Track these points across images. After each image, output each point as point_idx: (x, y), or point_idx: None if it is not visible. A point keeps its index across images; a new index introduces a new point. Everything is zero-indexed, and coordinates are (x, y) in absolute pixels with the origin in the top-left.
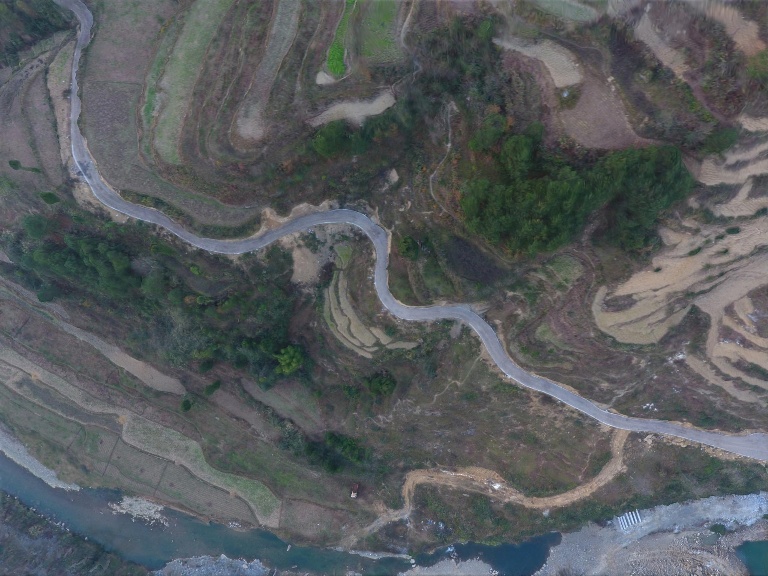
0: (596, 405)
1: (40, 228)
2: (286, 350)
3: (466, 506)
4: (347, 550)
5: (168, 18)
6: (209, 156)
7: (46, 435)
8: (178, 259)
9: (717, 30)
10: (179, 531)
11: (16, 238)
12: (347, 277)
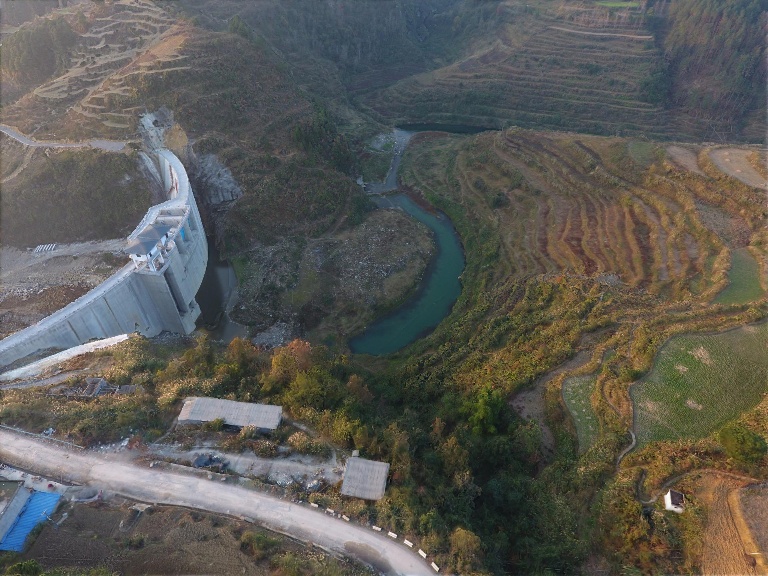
0: (27, 138)
1: None
2: None
3: None
4: None
5: None
6: None
7: None
8: None
9: None
10: None
11: None
12: None
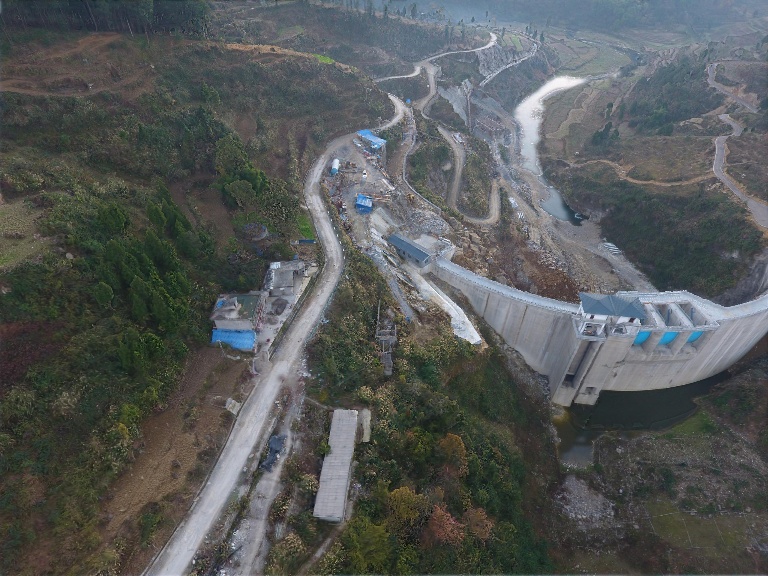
0: None
1: None
2: None
3: None
4: None
5: None
6: None
7: None
8: None
9: None
10: (531, 121)
11: None
12: None
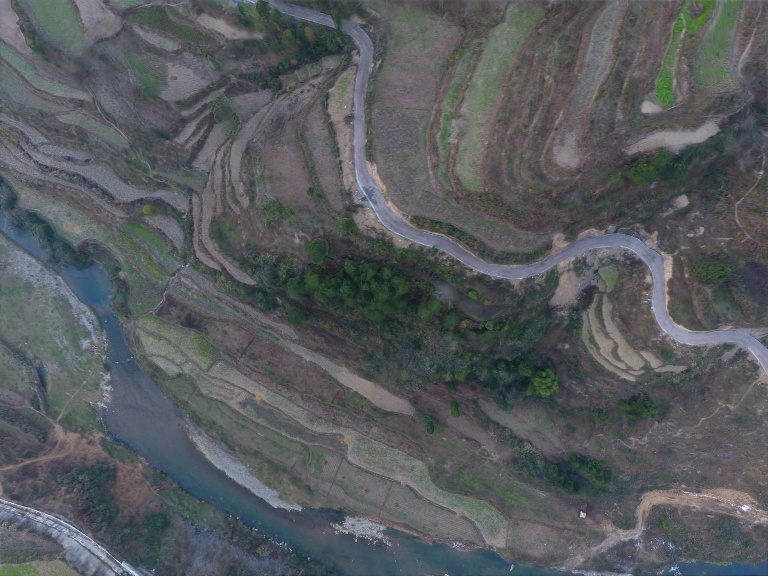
0: None
1: (324, 253)
2: (547, 373)
3: (708, 527)
4: (570, 570)
5: (456, 44)
6: (518, 184)
7: (270, 455)
8: (456, 284)
9: None
10: (402, 551)
11: (276, 261)
12: (616, 301)
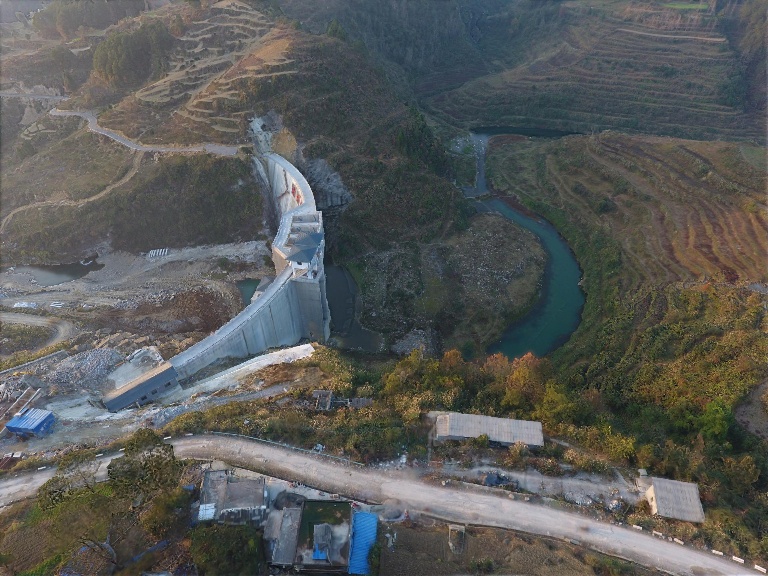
0: (133, 142)
1: None
2: None
3: None
4: None
5: None
6: None
7: None
8: None
9: (190, 7)
10: None
11: None
12: None
